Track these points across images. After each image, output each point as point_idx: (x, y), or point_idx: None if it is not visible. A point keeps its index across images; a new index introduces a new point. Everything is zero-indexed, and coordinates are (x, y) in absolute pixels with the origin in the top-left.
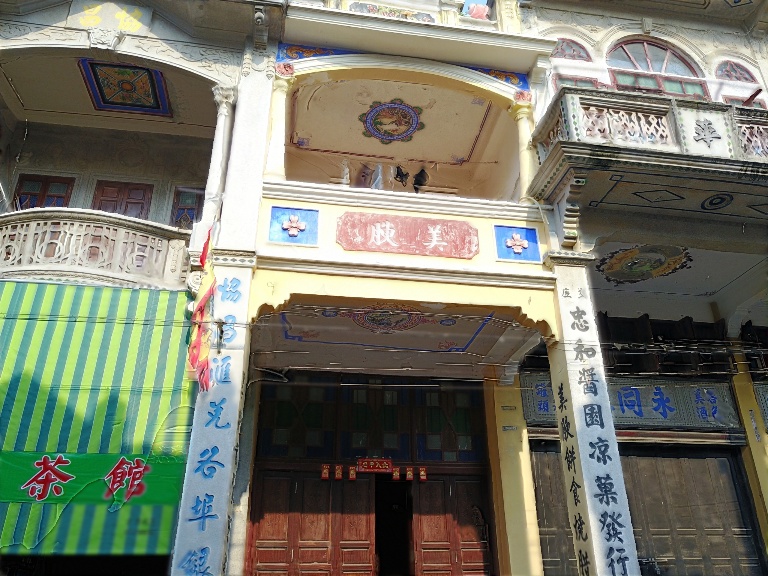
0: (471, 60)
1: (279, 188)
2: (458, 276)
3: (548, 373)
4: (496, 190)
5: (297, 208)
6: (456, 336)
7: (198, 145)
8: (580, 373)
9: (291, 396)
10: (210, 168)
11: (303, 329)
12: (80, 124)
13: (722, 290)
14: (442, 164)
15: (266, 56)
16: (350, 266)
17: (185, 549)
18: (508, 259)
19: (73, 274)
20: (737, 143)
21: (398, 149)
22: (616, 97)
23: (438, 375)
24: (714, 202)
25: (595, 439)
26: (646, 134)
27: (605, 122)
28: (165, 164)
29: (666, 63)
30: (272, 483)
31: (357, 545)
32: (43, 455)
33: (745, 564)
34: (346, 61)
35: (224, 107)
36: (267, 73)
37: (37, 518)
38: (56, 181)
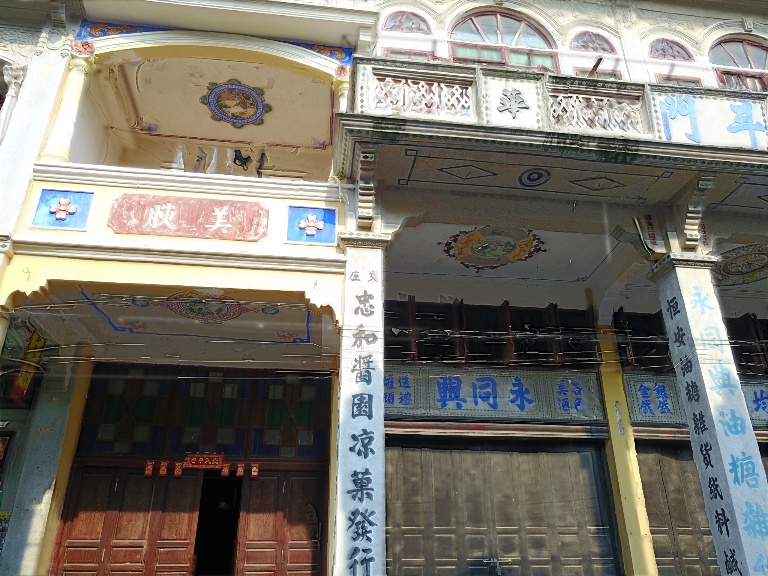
0: (290, 34)
1: (51, 170)
2: (236, 259)
3: (339, 362)
4: None
5: (70, 190)
6: (290, 326)
7: None
8: (355, 361)
9: (123, 390)
10: None
11: (125, 320)
12: None
13: (593, 275)
14: (304, 148)
15: (65, 34)
16: (116, 250)
17: None
18: (298, 241)
19: None
20: (546, 113)
21: (253, 133)
22: (414, 67)
23: (283, 367)
24: (532, 178)
25: (359, 431)
26: (445, 105)
27: (400, 93)
28: None
29: (518, 35)
30: (91, 480)
31: (174, 544)
32: None
33: (597, 564)
34: (154, 38)
35: (12, 88)
36: (62, 52)
37: None
38: None
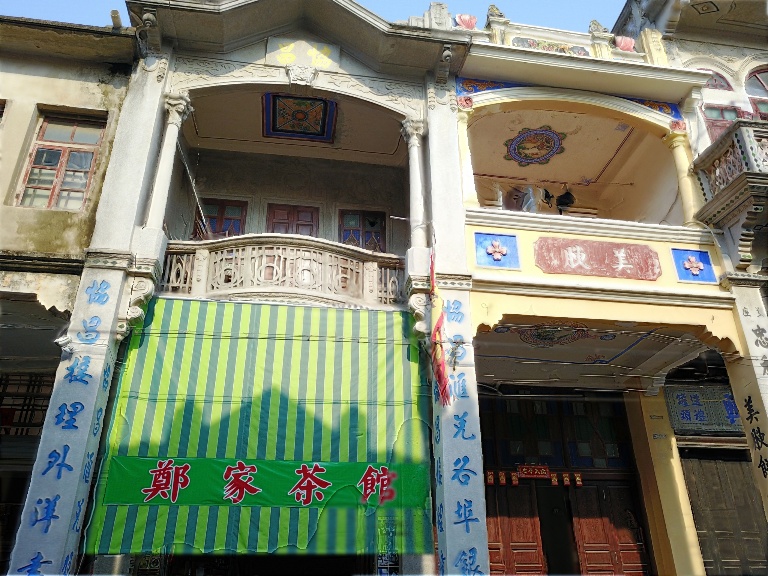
0: (630, 92)
1: (480, 215)
2: (648, 297)
3: (728, 386)
4: (638, 211)
5: (497, 234)
6: (608, 350)
7: (354, 169)
8: None
9: None
10: (412, 196)
11: None
12: (247, 150)
13: None
14: (571, 184)
15: (447, 90)
16: (553, 288)
17: (455, 549)
18: (688, 280)
19: (294, 296)
20: None
21: (533, 171)
22: None
23: (582, 386)
24: None
25: None
26: None
27: None
28: (326, 187)
29: None
30: None
31: (527, 547)
32: (301, 464)
33: None
34: (517, 94)
35: (415, 139)
36: (451, 106)
37: (306, 521)
38: (232, 204)
